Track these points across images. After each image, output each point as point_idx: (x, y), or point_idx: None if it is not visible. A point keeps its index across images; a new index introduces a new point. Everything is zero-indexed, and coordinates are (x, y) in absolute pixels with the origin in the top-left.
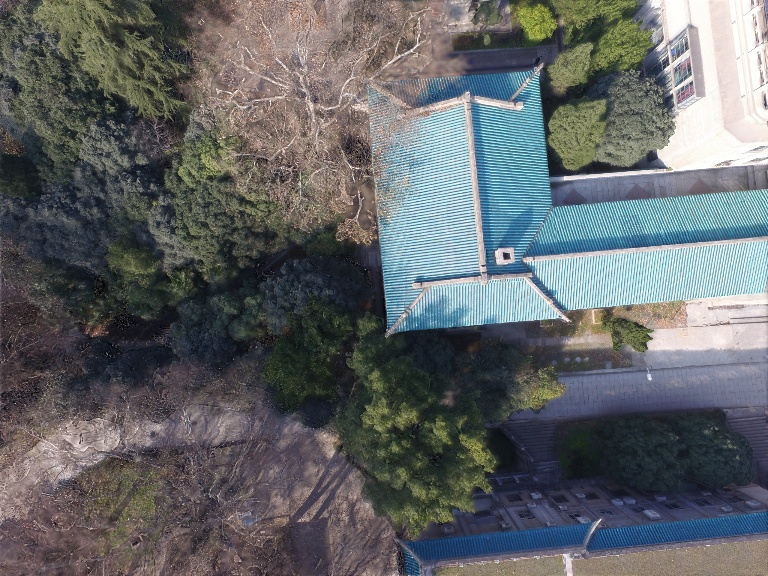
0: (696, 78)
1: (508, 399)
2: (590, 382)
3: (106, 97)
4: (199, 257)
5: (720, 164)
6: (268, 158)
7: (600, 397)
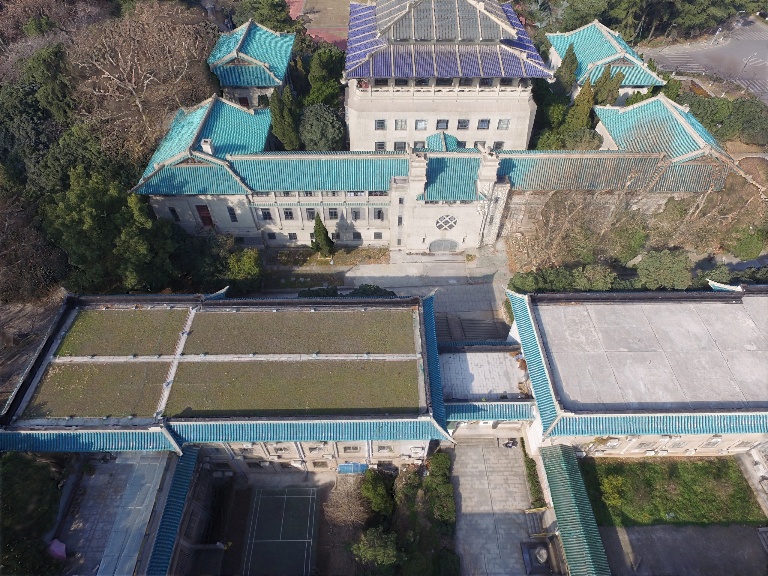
0: (346, 100)
1: (214, 260)
2: None
3: (40, 108)
4: (48, 183)
5: None
6: (103, 118)
7: None
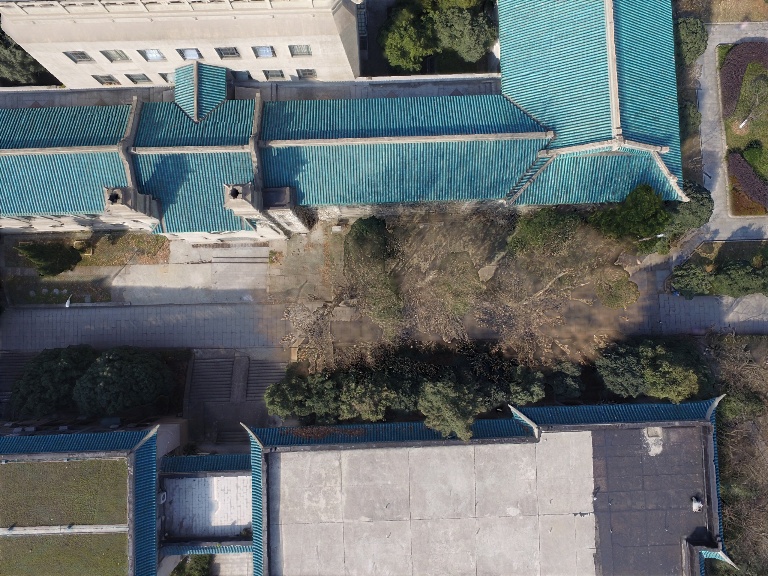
0: None
1: None
2: (72, 316)
3: None
4: None
5: (110, 82)
6: None
7: (80, 331)
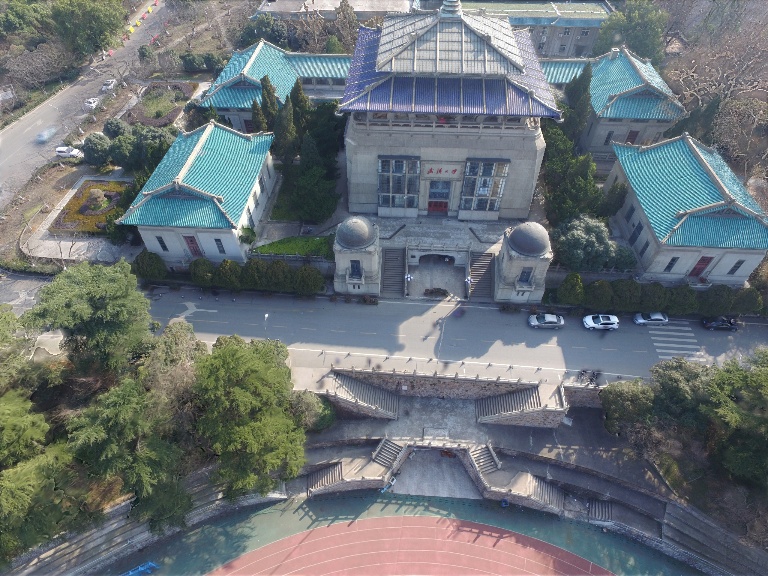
0: None
1: None
2: None
3: None
4: None
5: None
6: None
7: None
